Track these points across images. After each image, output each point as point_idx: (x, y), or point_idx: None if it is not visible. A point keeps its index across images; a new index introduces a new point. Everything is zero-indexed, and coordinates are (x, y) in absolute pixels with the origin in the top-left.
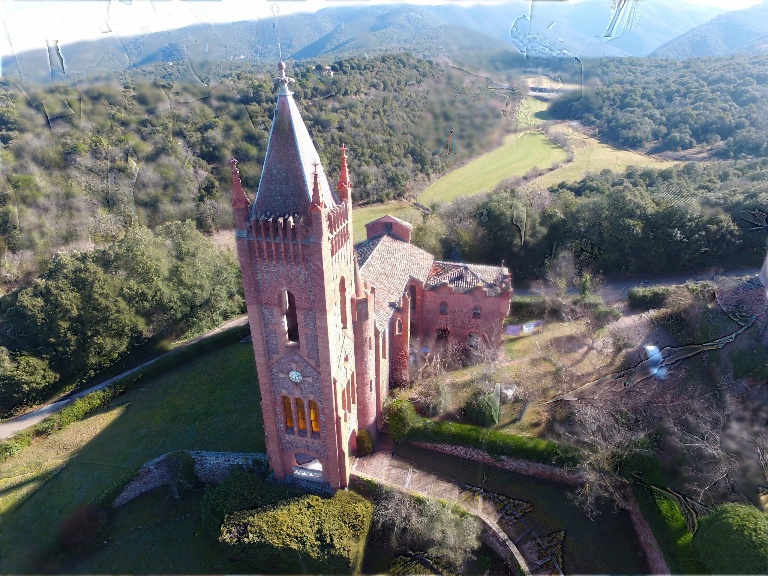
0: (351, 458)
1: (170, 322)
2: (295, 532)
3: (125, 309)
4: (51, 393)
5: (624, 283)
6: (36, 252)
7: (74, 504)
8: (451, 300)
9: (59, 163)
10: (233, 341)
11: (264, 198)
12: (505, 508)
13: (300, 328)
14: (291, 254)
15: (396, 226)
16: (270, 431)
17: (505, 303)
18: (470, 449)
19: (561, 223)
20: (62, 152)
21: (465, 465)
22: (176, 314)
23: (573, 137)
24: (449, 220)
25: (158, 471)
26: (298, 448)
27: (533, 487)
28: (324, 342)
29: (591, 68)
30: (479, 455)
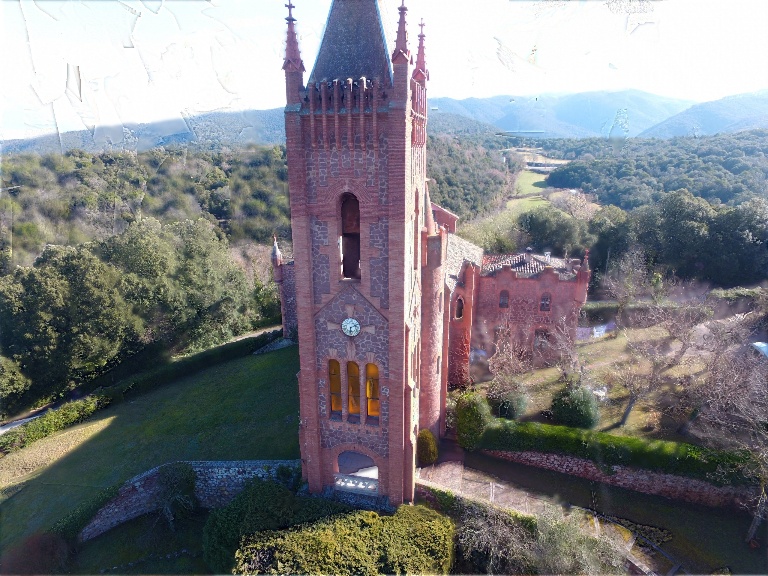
0: None
1: (172, 330)
2: (347, 560)
3: (121, 305)
4: (19, 407)
5: (693, 293)
6: None
7: (25, 536)
8: (513, 288)
9: (64, 179)
10: (245, 353)
11: (325, 64)
12: (634, 536)
13: (363, 249)
14: (361, 130)
15: (440, 215)
16: (308, 416)
17: (582, 288)
18: (568, 458)
19: (612, 231)
20: (69, 170)
21: (563, 480)
22: (180, 319)
23: (604, 160)
24: None
25: (146, 491)
26: (345, 442)
27: (663, 509)
28: (397, 265)
29: (621, 89)
30: (580, 467)
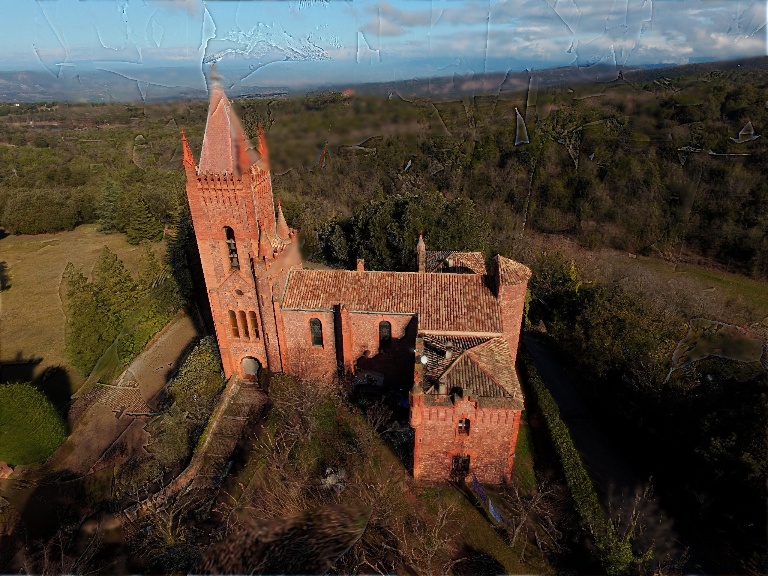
0: (255, 378)
1: None
2: None
3: (382, 239)
4: (350, 267)
5: None
6: (480, 201)
7: None
8: None
9: None
10: None
11: None
12: None
13: None
14: None
15: None
16: None
17: None
18: None
19: None
20: None
21: None
22: None
23: None
24: (759, 361)
25: None
26: None
27: None
28: None
29: None
30: None
